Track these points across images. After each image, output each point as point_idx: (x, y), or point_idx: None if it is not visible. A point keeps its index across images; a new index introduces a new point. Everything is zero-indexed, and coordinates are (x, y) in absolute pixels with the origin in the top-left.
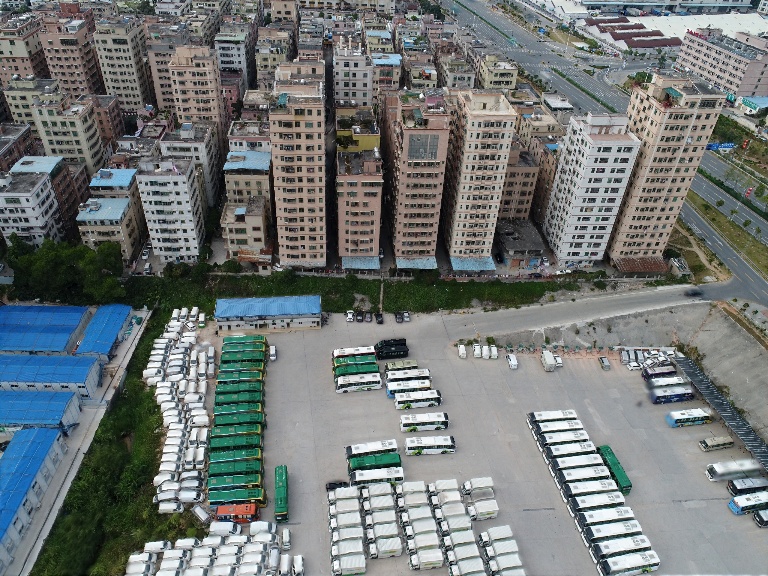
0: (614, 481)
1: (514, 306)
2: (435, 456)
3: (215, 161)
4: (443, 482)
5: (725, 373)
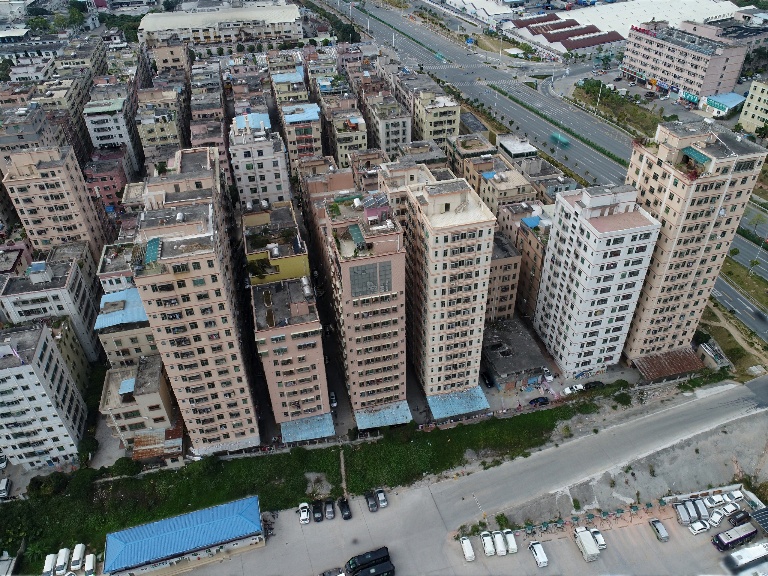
0: None
1: (521, 454)
2: None
3: (93, 294)
4: None
5: None
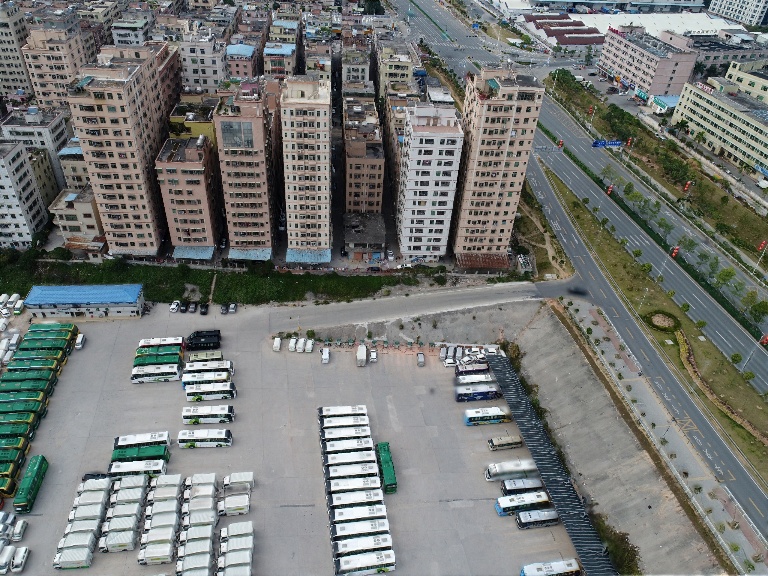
0: (379, 479)
1: (346, 300)
2: (210, 449)
3: None
4: (201, 476)
5: (539, 372)
